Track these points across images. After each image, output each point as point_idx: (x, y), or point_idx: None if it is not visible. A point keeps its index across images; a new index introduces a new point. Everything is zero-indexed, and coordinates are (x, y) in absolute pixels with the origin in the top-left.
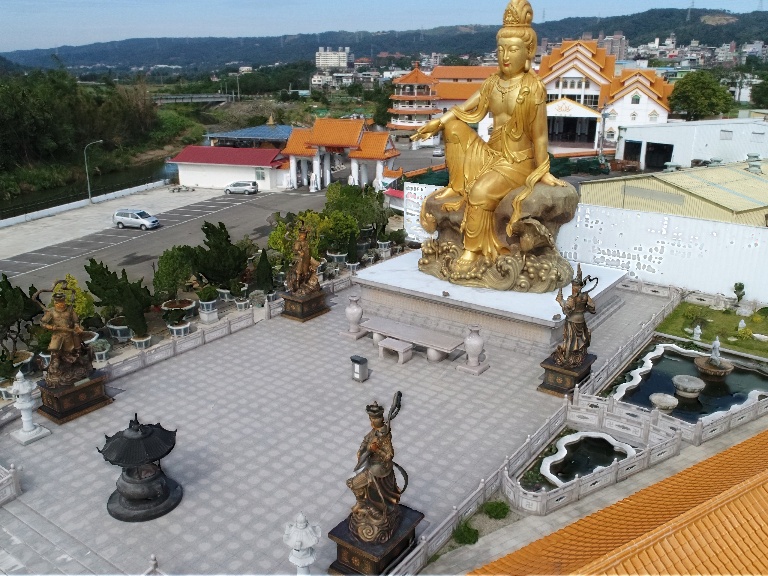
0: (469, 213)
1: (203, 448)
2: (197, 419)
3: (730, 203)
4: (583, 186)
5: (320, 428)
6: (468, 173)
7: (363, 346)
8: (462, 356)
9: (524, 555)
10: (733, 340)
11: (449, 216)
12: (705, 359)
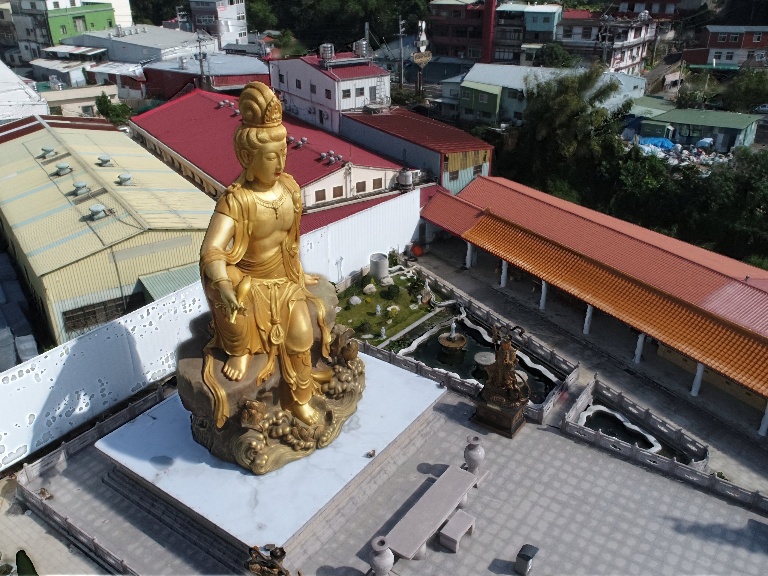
0: (303, 363)
1: None
2: None
3: None
4: (46, 277)
5: None
6: (261, 323)
7: (423, 571)
8: None
9: None
10: (392, 322)
11: (266, 386)
12: (446, 341)
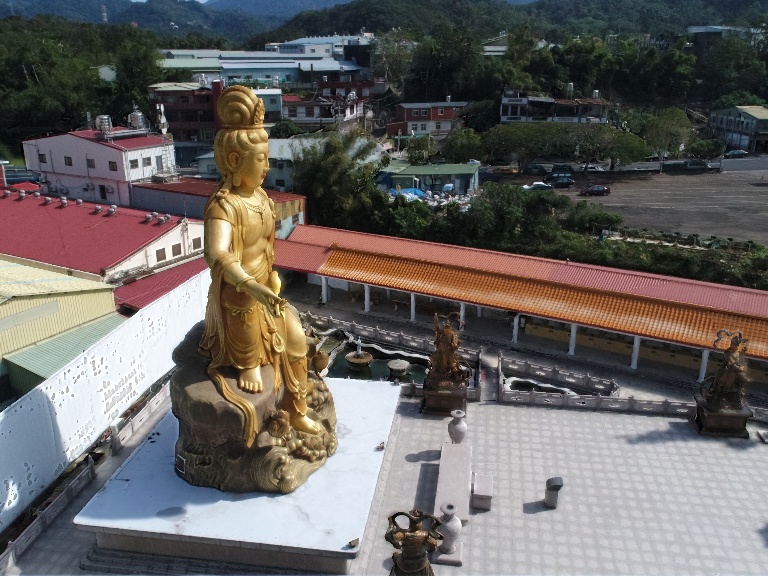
0: None
1: (762, 540)
2: (744, 572)
3: (93, 285)
4: None
5: (651, 493)
6: None
7: (475, 533)
8: (437, 463)
9: (710, 343)
10: None
11: None
12: (355, 359)
